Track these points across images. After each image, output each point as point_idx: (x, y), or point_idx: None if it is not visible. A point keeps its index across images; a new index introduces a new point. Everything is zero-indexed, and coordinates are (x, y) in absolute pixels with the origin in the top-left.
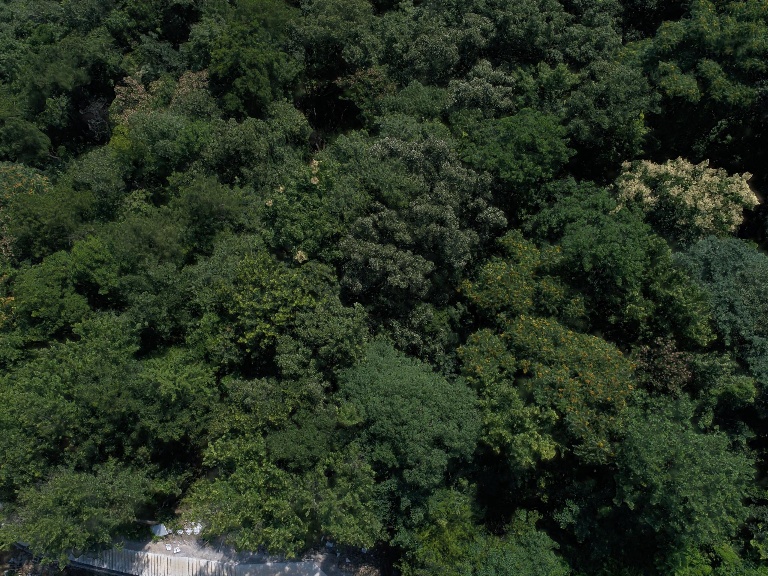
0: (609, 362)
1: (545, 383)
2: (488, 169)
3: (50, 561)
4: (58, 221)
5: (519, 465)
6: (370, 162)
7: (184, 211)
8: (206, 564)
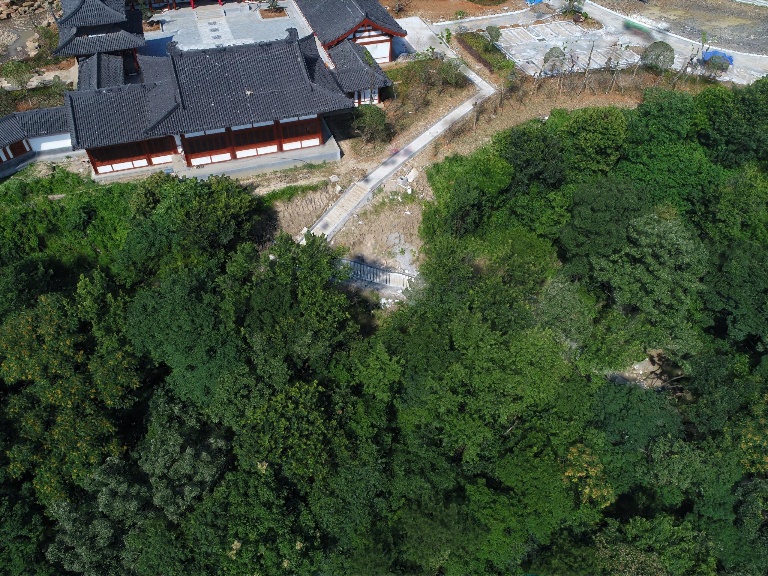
0: (6, 343)
1: (65, 331)
2: (48, 564)
3: (447, 240)
4: (549, 568)
5: None
6: (172, 567)
7: (411, 575)
8: (375, 279)
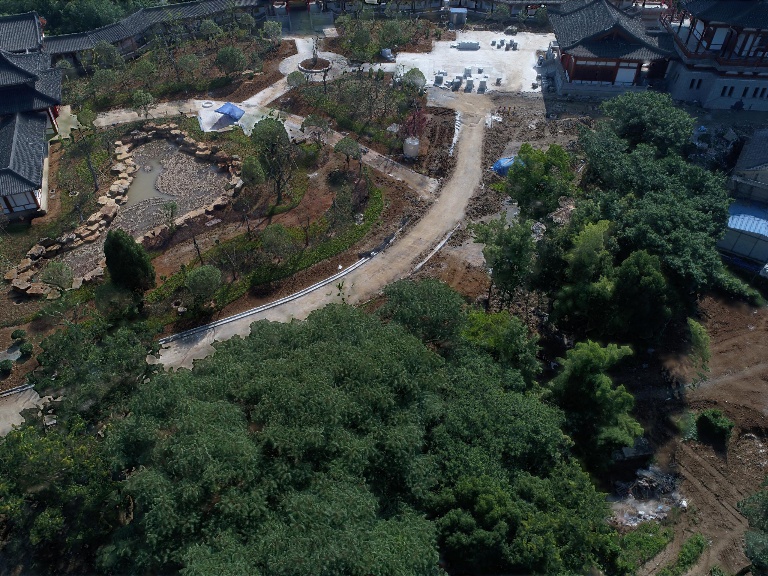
0: None
1: None
2: None
3: None
4: None
5: (38, 0)
6: None
7: None
8: None
